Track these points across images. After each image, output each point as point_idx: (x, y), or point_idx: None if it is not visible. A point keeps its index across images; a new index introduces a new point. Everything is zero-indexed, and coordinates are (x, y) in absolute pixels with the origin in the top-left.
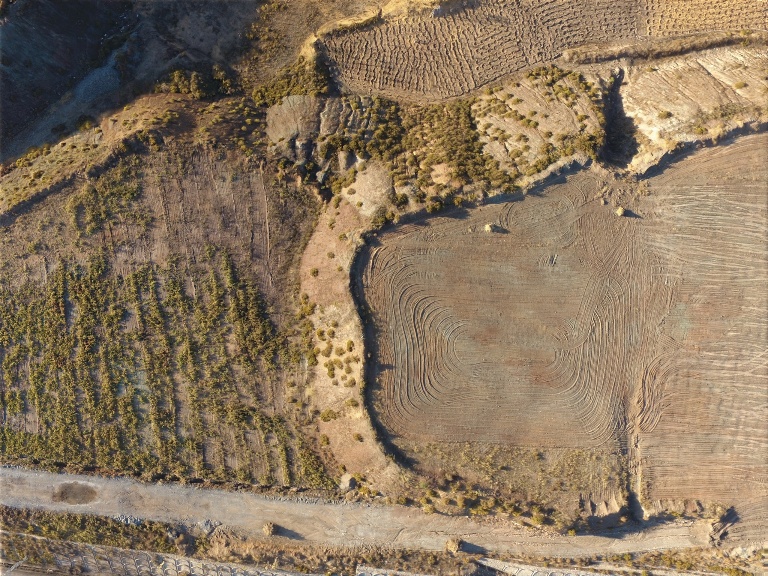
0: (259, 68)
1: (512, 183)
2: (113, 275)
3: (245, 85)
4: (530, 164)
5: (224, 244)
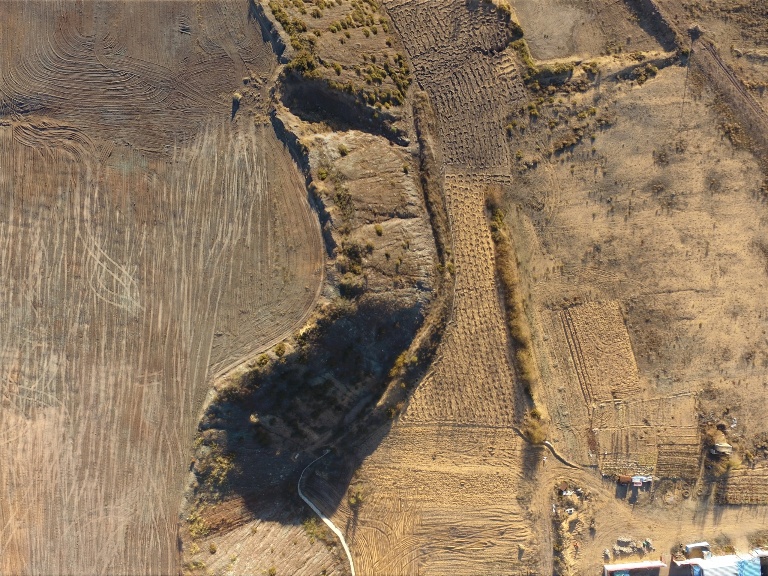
0: None
1: None
2: None
3: None
4: (283, 8)
5: None
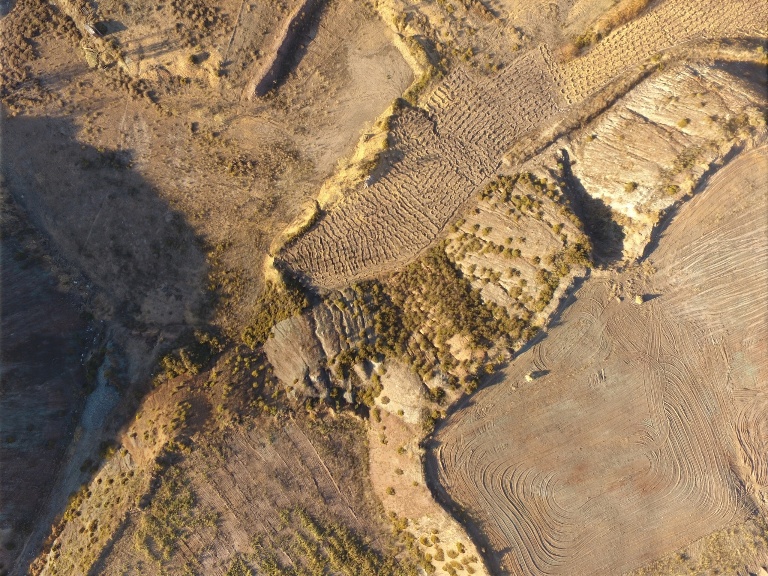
0: (235, 312)
1: (529, 325)
2: None
3: (231, 334)
4: (535, 299)
5: (294, 502)
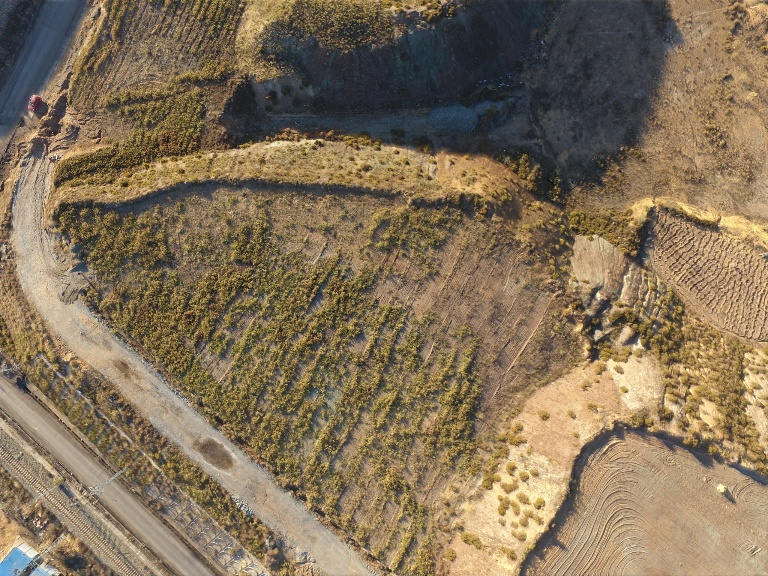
0: (590, 195)
1: (765, 464)
2: (372, 296)
3: (570, 202)
4: None
5: (480, 334)
